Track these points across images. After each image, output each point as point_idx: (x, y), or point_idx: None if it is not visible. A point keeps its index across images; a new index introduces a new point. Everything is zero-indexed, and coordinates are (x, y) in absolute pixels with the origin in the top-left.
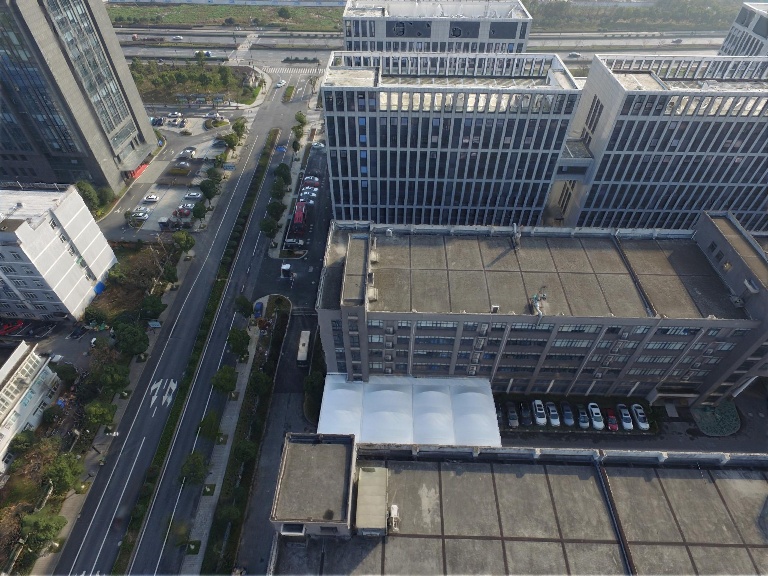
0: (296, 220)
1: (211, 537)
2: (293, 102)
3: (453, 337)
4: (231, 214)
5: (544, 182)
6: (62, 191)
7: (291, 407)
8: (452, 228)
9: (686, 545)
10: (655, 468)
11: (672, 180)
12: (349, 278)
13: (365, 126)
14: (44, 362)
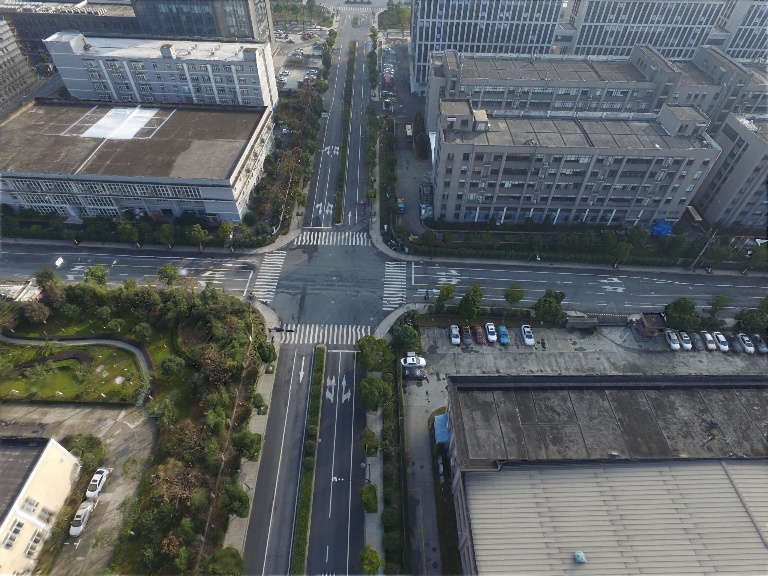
0: (387, 81)
1: (382, 192)
2: (360, 27)
3: (502, 100)
4: (340, 82)
5: (547, 46)
6: (261, 43)
7: (407, 155)
8: (497, 54)
9: (611, 134)
10: (600, 120)
11: (623, 44)
12: (450, 63)
13: (443, 4)
14: (273, 124)
